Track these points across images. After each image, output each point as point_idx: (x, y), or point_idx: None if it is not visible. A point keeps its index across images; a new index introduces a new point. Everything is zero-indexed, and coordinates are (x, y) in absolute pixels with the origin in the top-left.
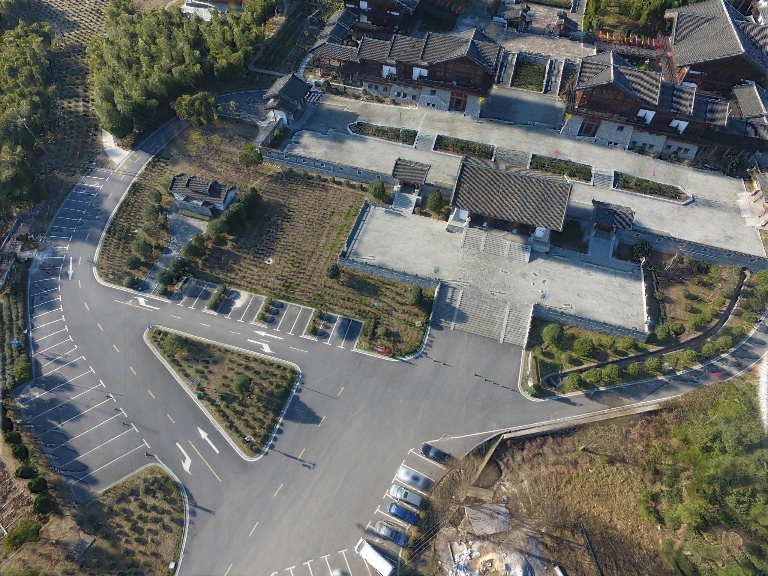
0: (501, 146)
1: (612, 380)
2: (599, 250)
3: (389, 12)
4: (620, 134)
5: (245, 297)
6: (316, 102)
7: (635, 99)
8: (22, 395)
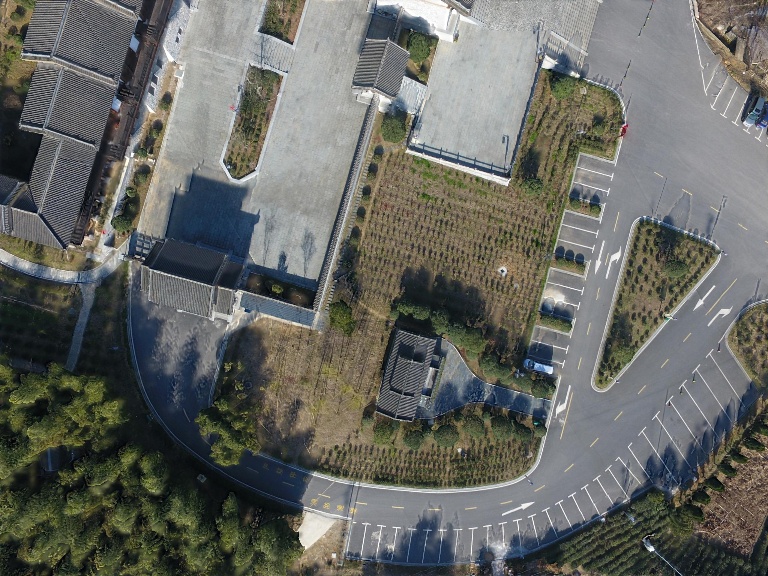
0: None
1: None
2: None
3: None
4: None
5: (551, 292)
6: None
7: None
8: (670, 489)
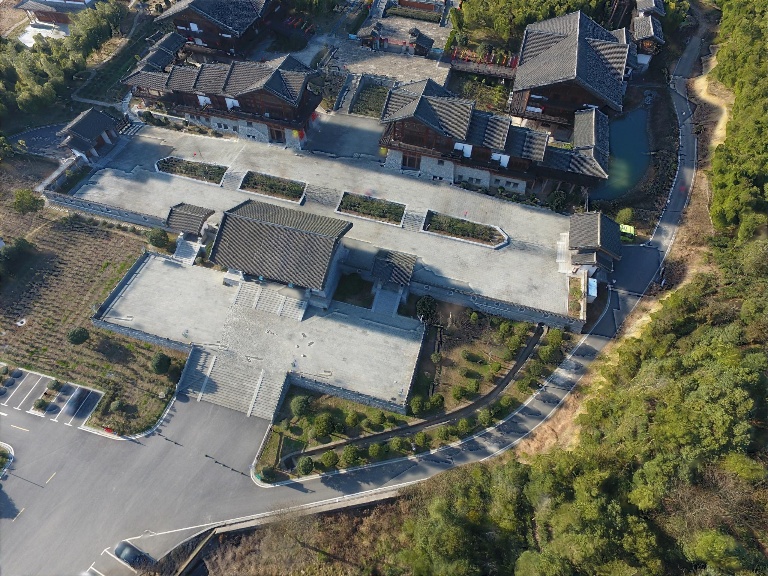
0: (313, 183)
1: (356, 461)
2: (384, 305)
3: (221, 34)
4: (442, 168)
5: None
6: (133, 135)
7: (441, 134)
8: None
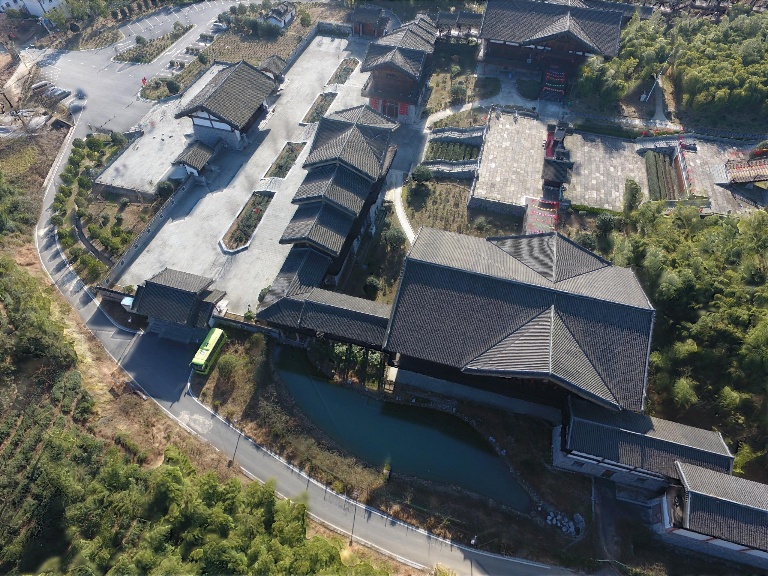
0: None
1: None
2: None
3: None
4: None
5: None
6: None
7: None
8: (173, 7)
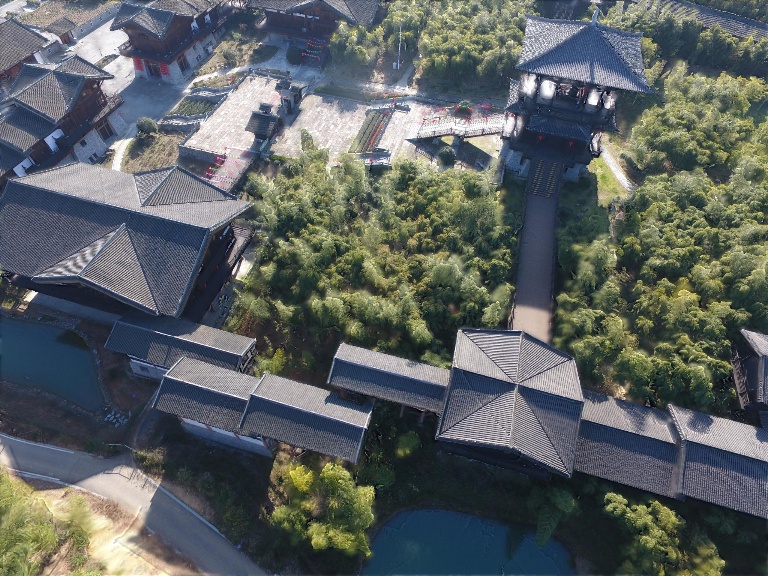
0: None
1: None
2: None
3: None
4: None
5: (30, 11)
6: None
7: None
8: None
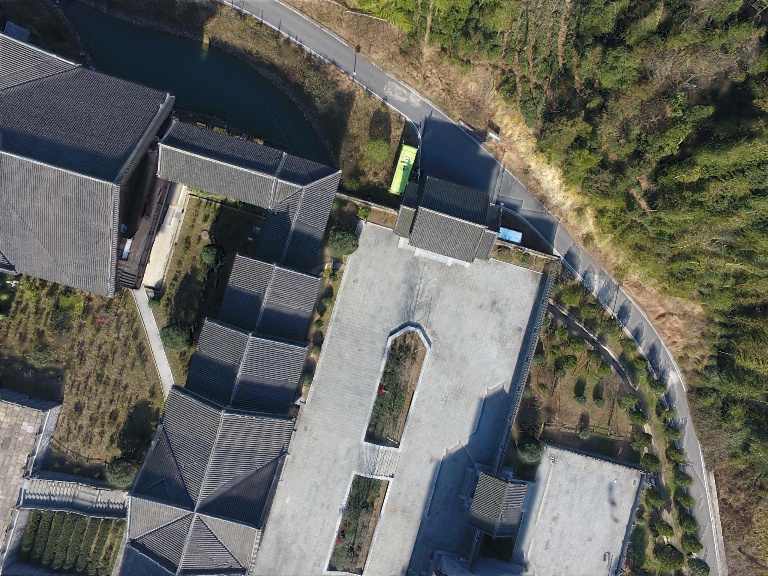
0: None
1: None
2: None
3: None
4: None
5: None
6: None
7: None
8: None
